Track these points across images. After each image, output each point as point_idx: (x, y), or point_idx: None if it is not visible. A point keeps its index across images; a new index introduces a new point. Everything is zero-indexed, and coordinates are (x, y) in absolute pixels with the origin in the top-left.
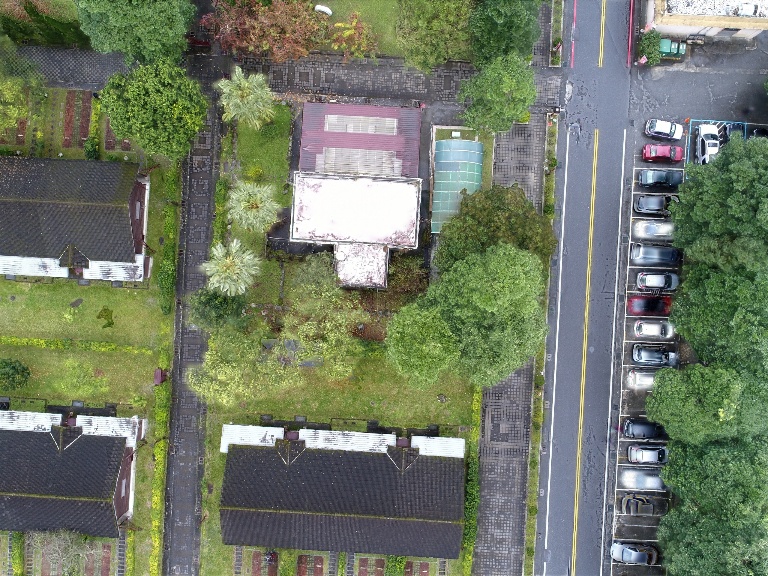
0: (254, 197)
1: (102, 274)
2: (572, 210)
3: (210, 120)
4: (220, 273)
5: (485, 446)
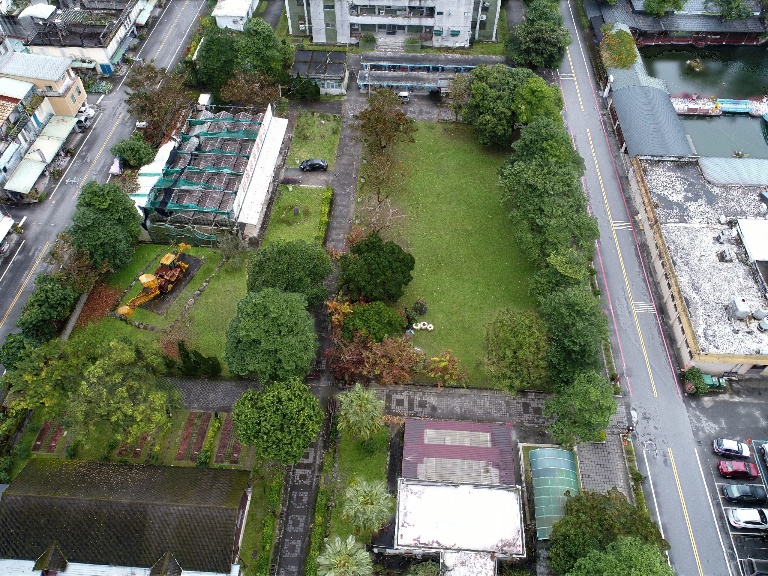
0: (369, 494)
1: None
2: (668, 525)
3: (314, 438)
4: (335, 570)
5: None
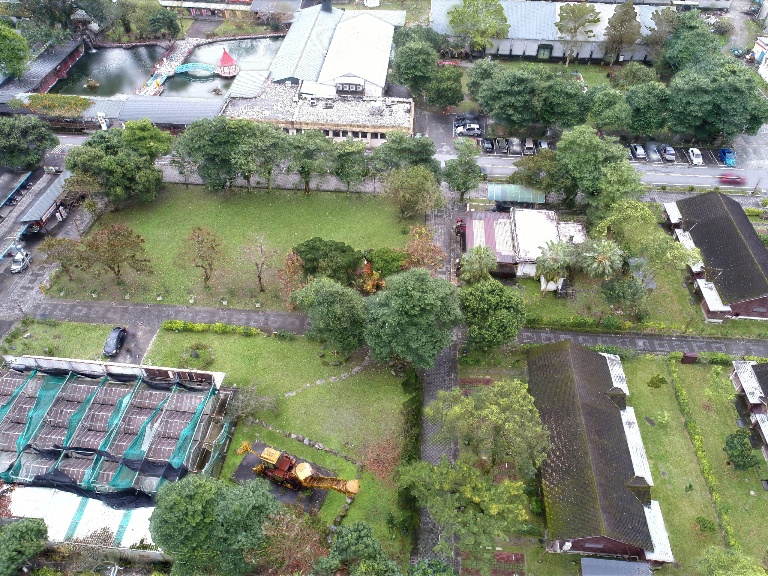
0: None
1: (622, 382)
2: (509, 174)
3: None
4: None
5: (662, 206)
